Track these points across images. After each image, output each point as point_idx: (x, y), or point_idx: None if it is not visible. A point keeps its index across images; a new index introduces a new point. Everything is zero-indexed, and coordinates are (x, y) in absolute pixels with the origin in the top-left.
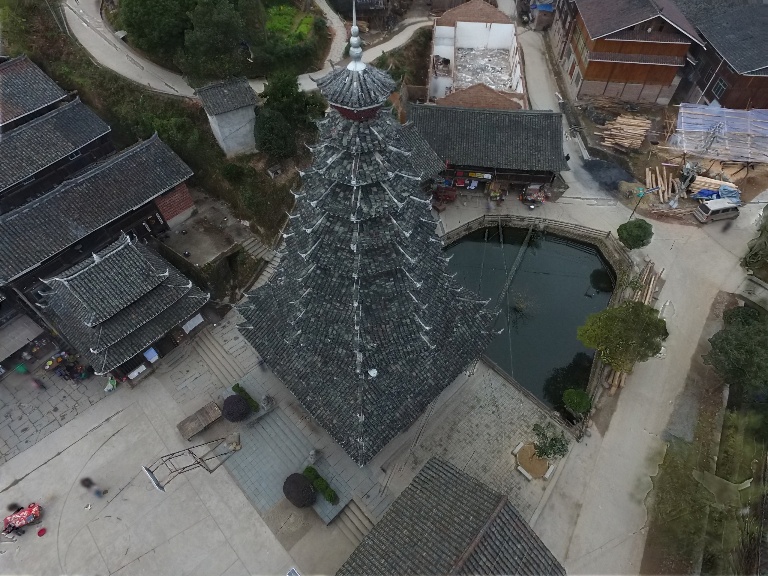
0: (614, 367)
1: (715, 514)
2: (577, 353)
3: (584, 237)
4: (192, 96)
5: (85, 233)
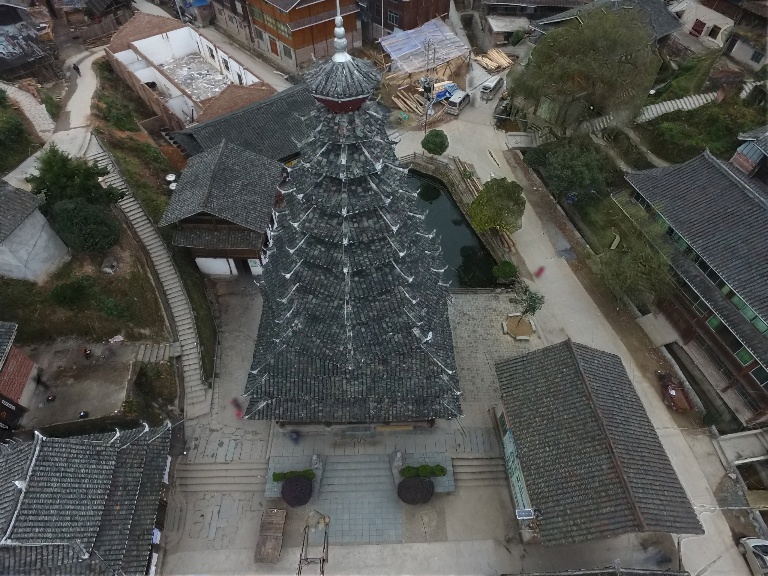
0: (511, 231)
1: None
2: (460, 249)
3: None
4: None
5: None
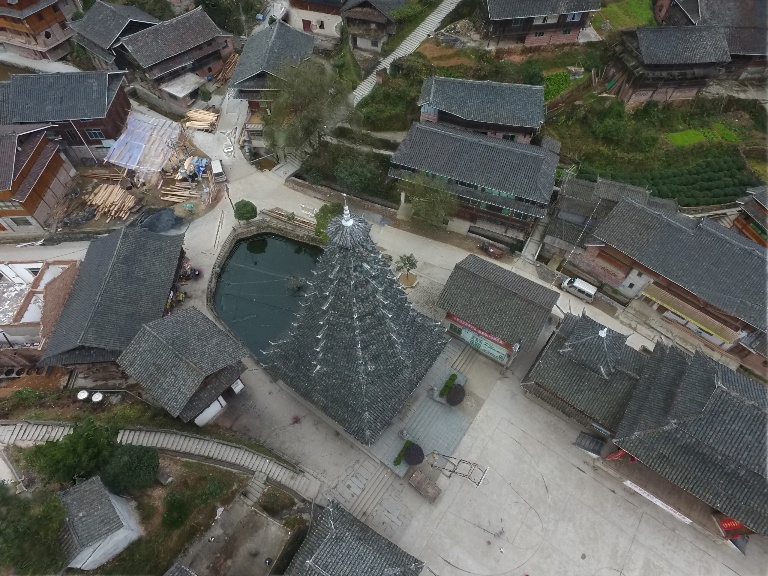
0: None
1: (416, 214)
2: None
3: (231, 244)
4: None
5: None
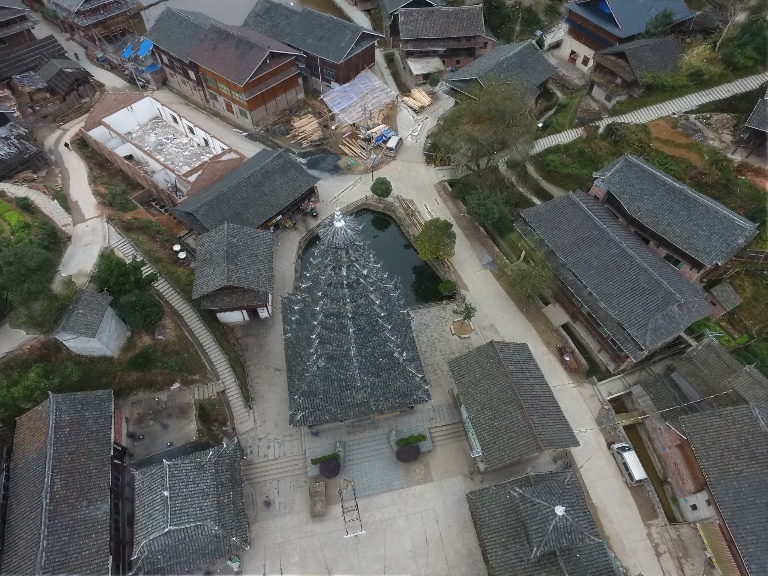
0: (448, 258)
1: None
2: (412, 269)
3: (356, 208)
4: (19, 345)
5: (108, 504)
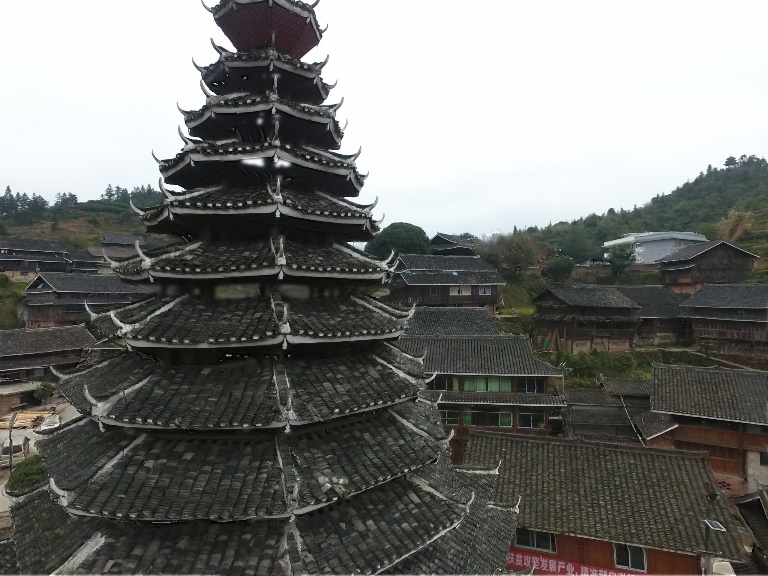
0: None
1: None
2: None
3: None
4: None
5: None
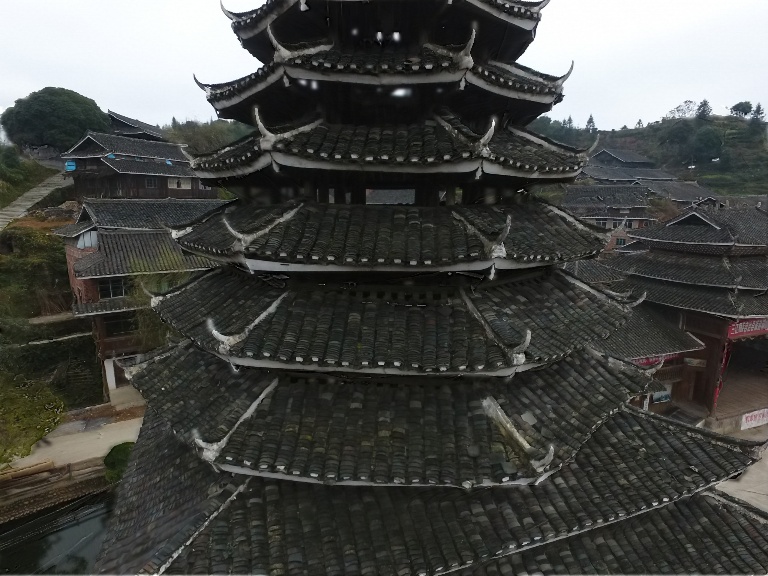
0: None
1: None
2: None
3: None
4: None
5: None
